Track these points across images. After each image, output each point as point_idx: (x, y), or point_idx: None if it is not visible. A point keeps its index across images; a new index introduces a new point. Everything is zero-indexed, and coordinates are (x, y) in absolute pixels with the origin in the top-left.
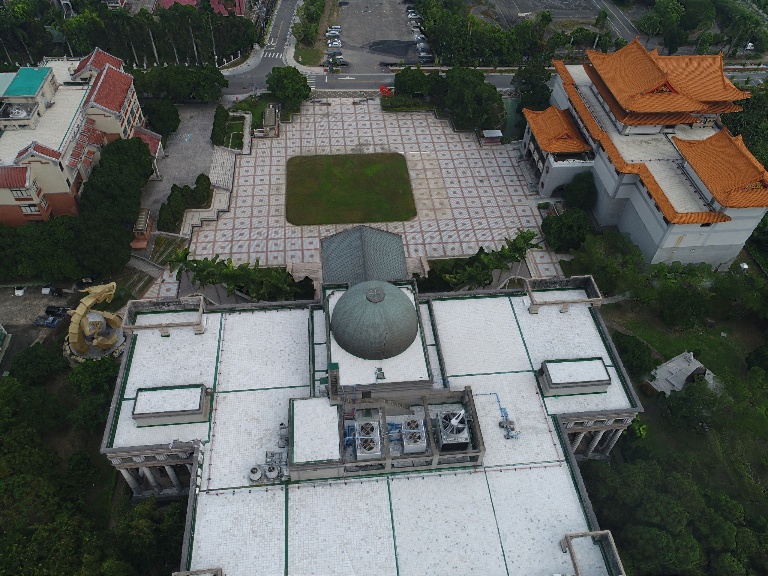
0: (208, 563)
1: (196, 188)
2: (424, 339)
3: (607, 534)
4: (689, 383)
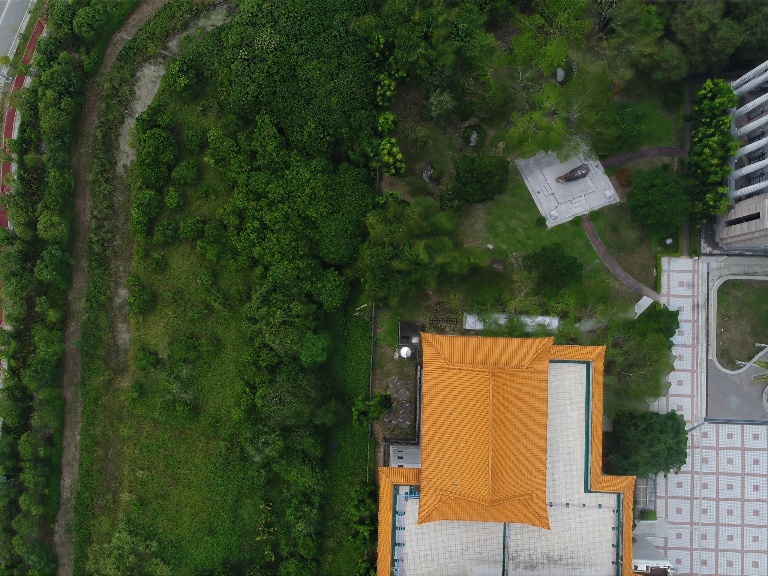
0: None
1: None
2: None
3: None
4: None
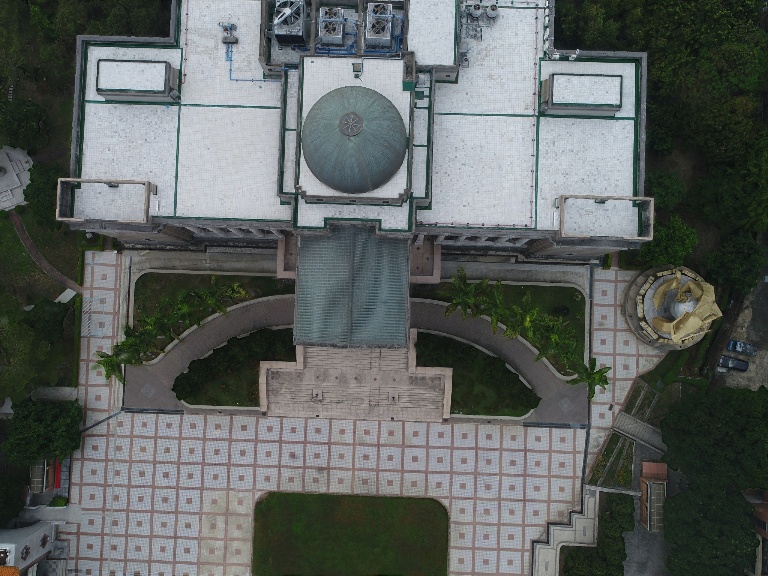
0: None
1: (586, 568)
2: (299, 112)
3: None
4: (1, 149)
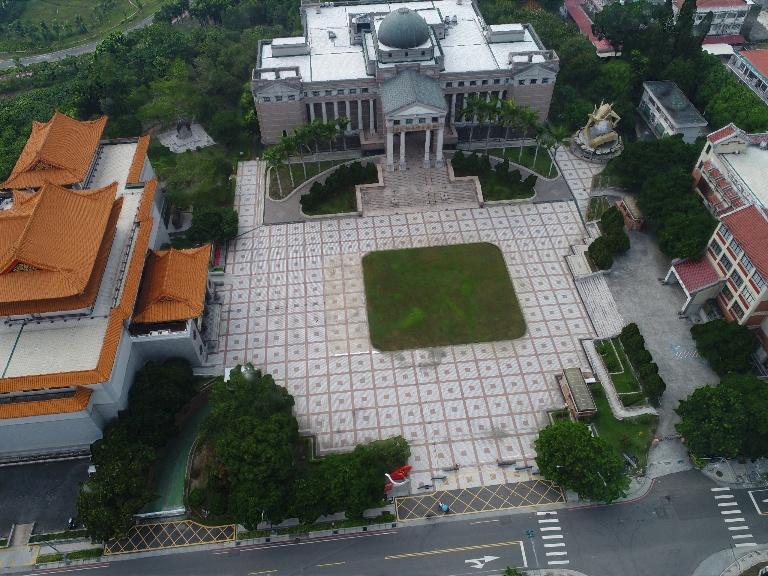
0: (466, 7)
1: (602, 237)
2: (375, 32)
3: (303, 5)
4: None
